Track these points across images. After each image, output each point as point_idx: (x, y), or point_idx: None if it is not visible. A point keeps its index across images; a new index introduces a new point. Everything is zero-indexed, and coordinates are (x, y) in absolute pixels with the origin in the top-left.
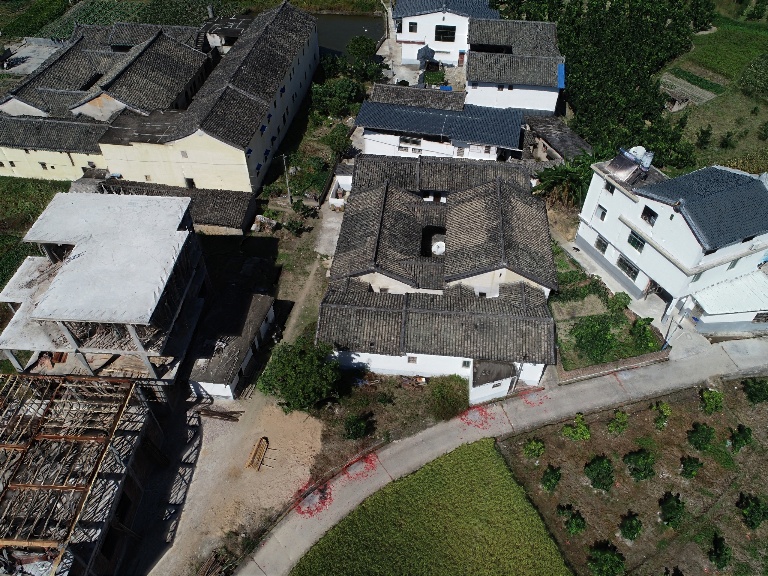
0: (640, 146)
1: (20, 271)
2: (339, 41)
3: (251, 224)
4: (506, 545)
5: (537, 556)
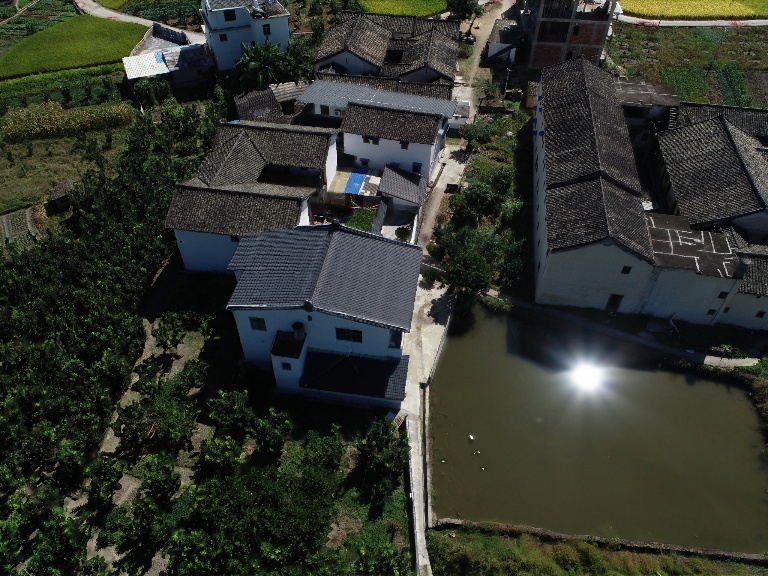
0: (254, 7)
1: (619, 8)
2: (523, 408)
3: (524, 94)
4: (380, 5)
5: (370, 3)
